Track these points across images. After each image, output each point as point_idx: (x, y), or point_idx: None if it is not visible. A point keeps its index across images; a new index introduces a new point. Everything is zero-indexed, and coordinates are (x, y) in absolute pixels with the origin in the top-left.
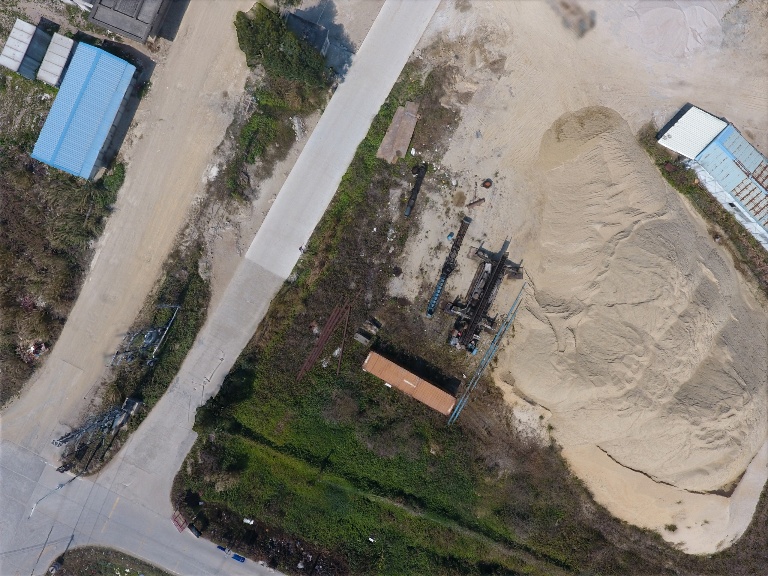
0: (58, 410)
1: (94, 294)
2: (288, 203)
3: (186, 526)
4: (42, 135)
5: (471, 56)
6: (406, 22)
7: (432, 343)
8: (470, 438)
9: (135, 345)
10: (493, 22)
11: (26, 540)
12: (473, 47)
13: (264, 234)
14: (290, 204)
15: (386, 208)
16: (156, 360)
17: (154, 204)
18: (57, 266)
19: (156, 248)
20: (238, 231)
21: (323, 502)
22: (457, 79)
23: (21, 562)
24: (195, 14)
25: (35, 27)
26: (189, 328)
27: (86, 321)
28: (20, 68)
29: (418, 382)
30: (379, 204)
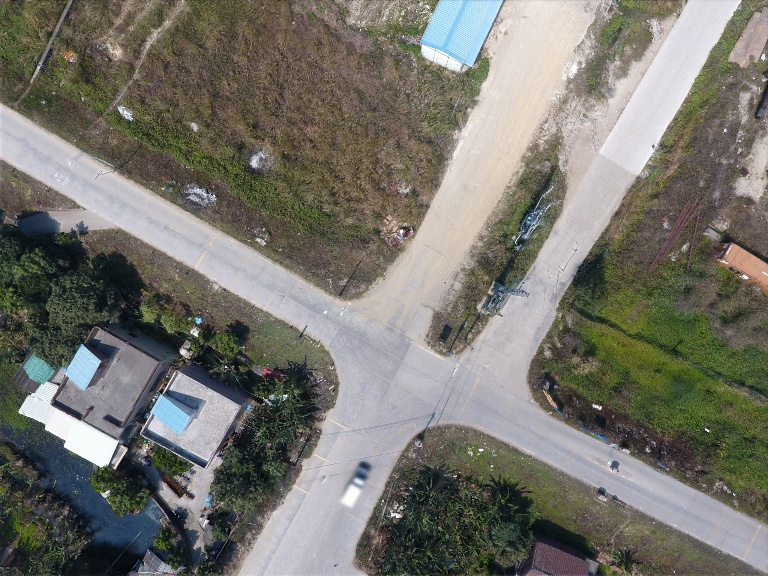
0: (420, 293)
1: (456, 183)
2: (643, 102)
3: None
4: (432, 22)
5: None
6: None
7: None
8: None
9: (494, 233)
10: None
11: (388, 417)
12: None
13: (619, 131)
14: (645, 103)
15: (736, 110)
16: None
17: (516, 98)
18: (430, 152)
19: (516, 141)
20: (594, 127)
21: (665, 392)
22: None
23: (381, 438)
24: None
25: None
26: (548, 218)
27: (447, 209)
28: None
29: None
30: (731, 106)
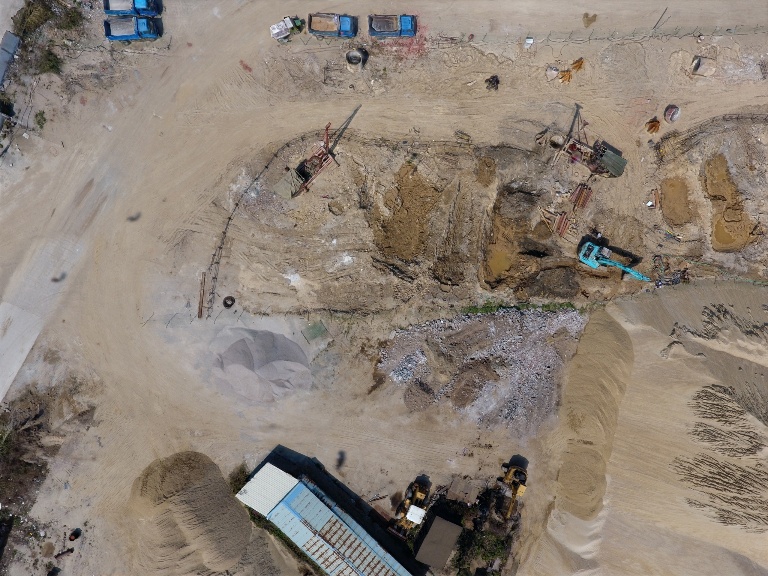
0: None
1: None
2: None
3: None
4: None
5: (59, 408)
6: None
7: None
8: None
9: None
10: (82, 373)
11: None
12: (61, 399)
13: None
14: None
15: None
16: None
17: None
18: None
19: None
20: None
21: None
22: (40, 435)
23: None
24: None
25: None
26: None
27: None
28: None
29: None
30: None
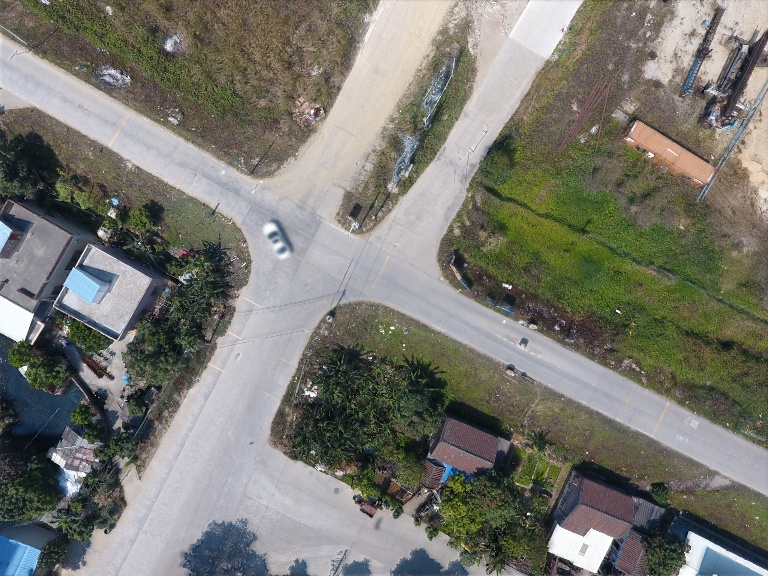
0: (332, 173)
1: (367, 66)
2: None
3: (459, 279)
4: None
5: None
6: None
7: (683, 124)
8: (717, 216)
9: (405, 115)
10: None
11: (299, 294)
12: None
13: (528, 15)
14: None
15: None
16: None
17: None
18: (339, 33)
19: (427, 24)
20: (504, 11)
21: (575, 272)
22: None
23: (293, 316)
24: None
25: None
26: (458, 99)
27: (359, 91)
28: None
29: (680, 151)
30: None
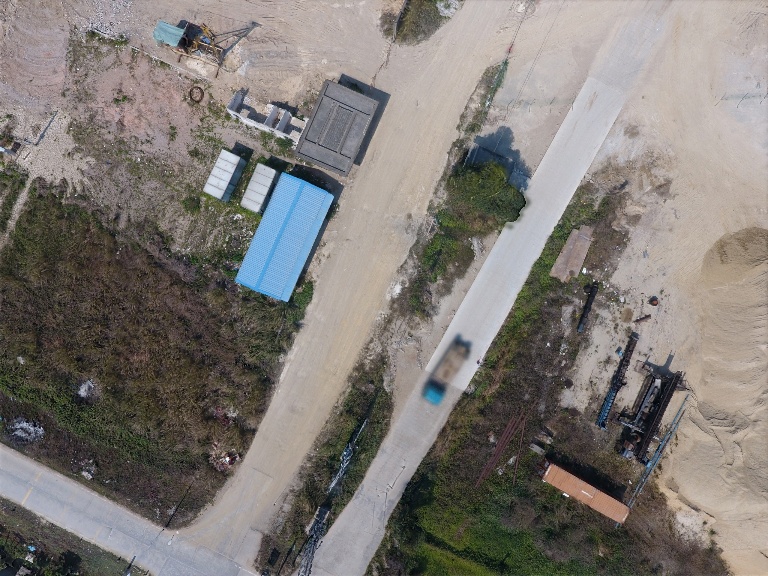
0: (249, 516)
1: (283, 405)
2: (467, 319)
3: None
4: (246, 261)
5: (639, 181)
6: (578, 148)
7: (600, 451)
8: (636, 541)
9: (322, 454)
10: (659, 148)
11: None
12: (640, 172)
13: (444, 348)
14: (469, 320)
15: (559, 324)
16: (346, 470)
17: (340, 320)
18: (253, 381)
19: (342, 361)
20: (419, 345)
21: None
22: (627, 203)
23: None
24: (381, 140)
25: (239, 158)
26: (374, 438)
27: (275, 431)
28: (223, 195)
29: (595, 493)
30: (553, 321)
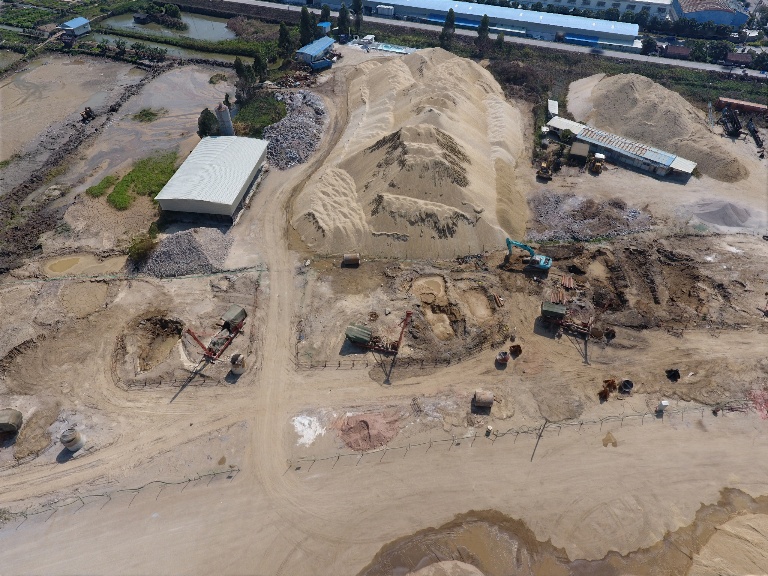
0: None
1: None
2: None
3: None
4: None
5: None
6: None
7: None
8: None
9: None
10: None
11: None
12: None
13: None
14: None
15: None
16: None
17: None
18: None
19: None
20: None
21: None
22: None
23: None
24: None
25: None
26: None
27: None
28: None
29: None
30: None
